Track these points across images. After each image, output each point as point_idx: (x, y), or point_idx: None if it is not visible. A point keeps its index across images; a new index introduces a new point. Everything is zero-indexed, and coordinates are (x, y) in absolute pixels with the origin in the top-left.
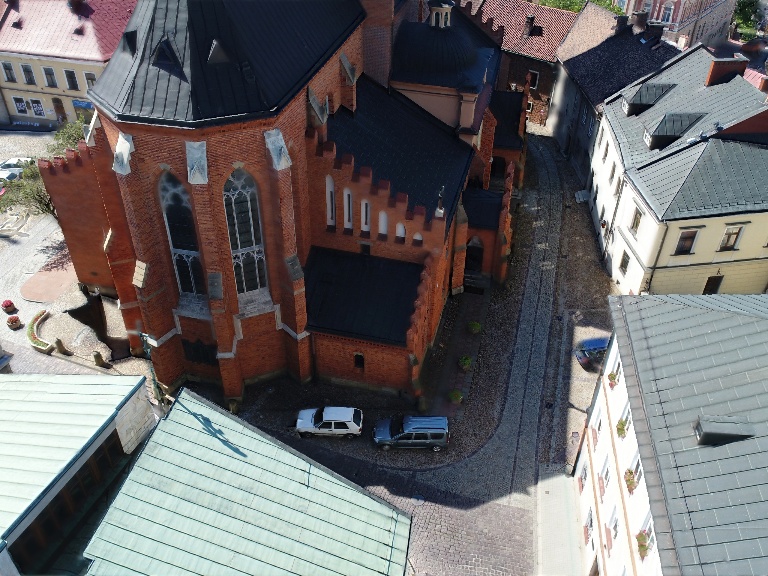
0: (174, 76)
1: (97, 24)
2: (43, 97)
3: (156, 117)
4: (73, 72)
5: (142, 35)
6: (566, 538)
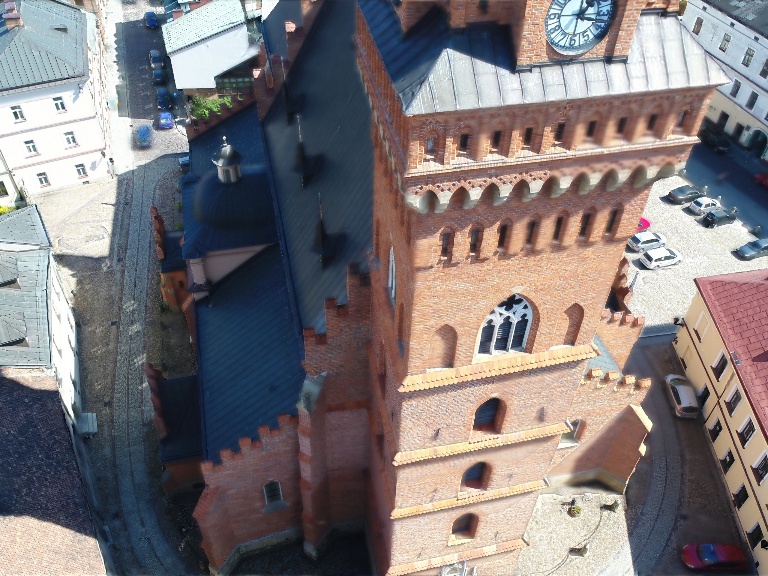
0: None
1: None
2: None
3: None
4: None
5: None
6: (119, 155)
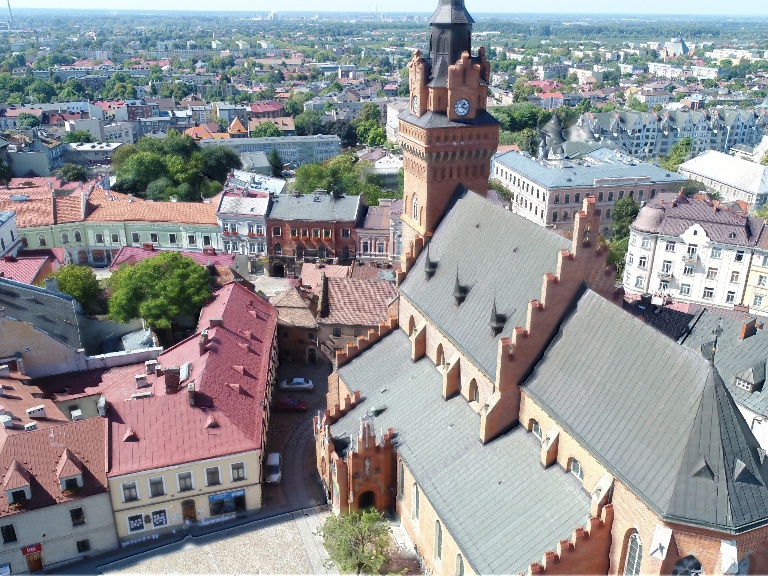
0: (753, 485)
1: (224, 411)
2: (171, 505)
3: (759, 520)
4: (216, 468)
5: (716, 462)
6: None
